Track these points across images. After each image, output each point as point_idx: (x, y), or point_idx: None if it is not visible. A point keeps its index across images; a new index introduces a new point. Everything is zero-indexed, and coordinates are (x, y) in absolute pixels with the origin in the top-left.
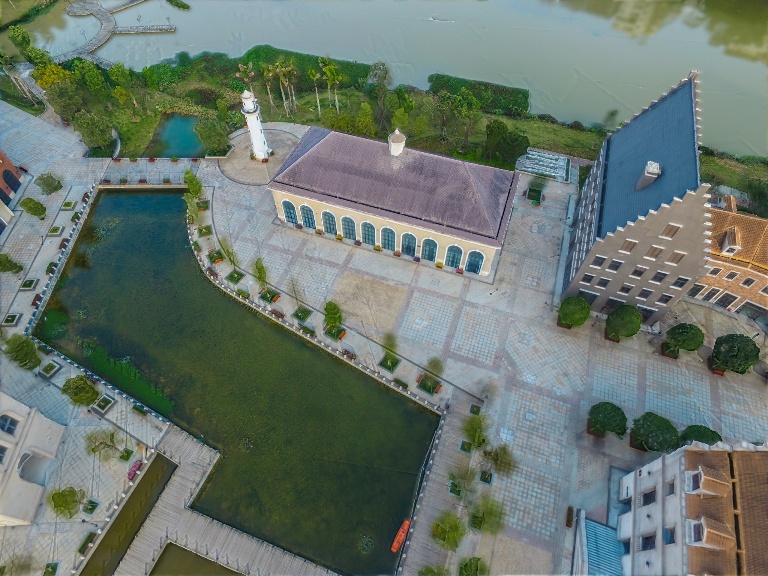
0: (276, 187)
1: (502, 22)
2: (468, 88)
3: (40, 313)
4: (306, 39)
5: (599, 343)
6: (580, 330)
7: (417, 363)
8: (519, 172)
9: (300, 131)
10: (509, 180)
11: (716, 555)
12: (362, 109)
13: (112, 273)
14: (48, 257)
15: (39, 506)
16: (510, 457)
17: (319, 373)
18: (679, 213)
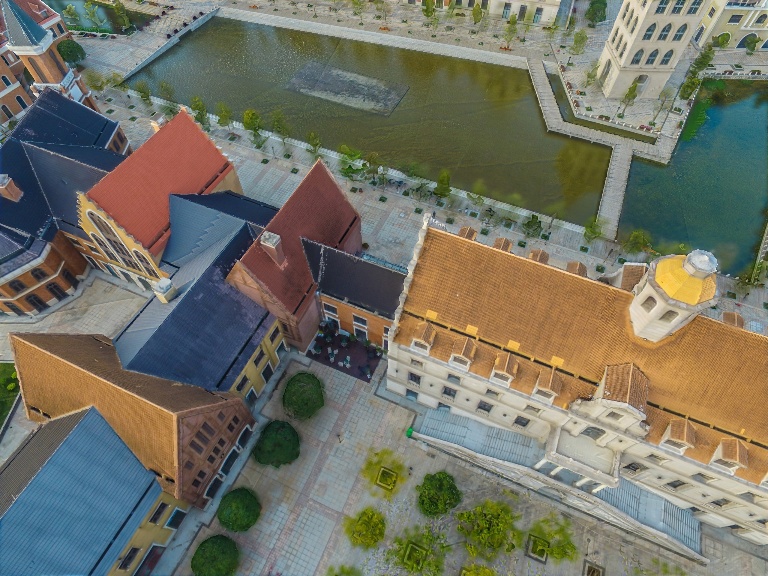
0: None
1: None
2: None
3: (719, 77)
4: None
5: None
6: None
7: None
8: None
9: None
10: None
11: None
12: None
13: (767, 101)
14: (763, 70)
15: (615, 99)
16: None
17: (748, 211)
18: None
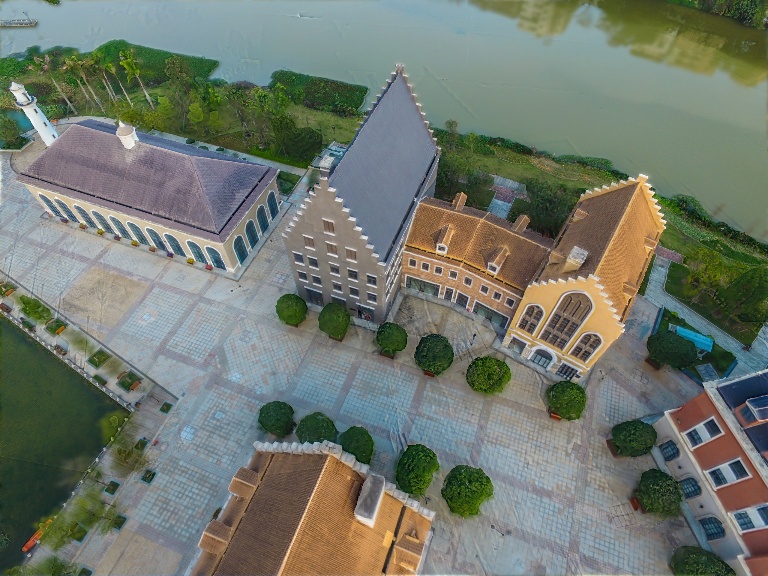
0: (22, 180)
1: (369, 19)
2: (307, 84)
3: None
4: (164, 34)
5: (321, 342)
6: (307, 328)
7: (127, 359)
8: (312, 169)
9: None
10: (258, 175)
11: (211, 559)
12: (161, 103)
13: None
14: None
15: None
16: (181, 456)
17: (27, 368)
18: (322, 208)
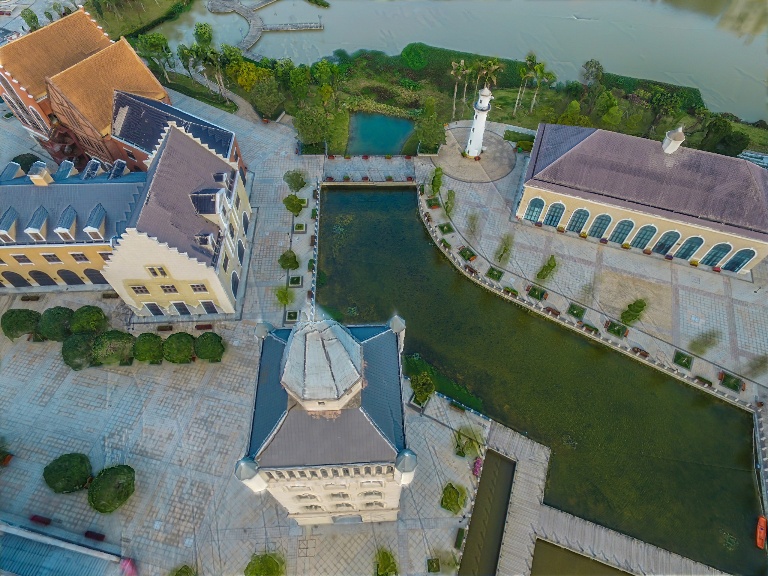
0: (535, 185)
1: (646, 21)
2: (638, 87)
3: (314, 310)
4: (457, 37)
5: None
6: None
7: (711, 361)
8: None
9: (499, 129)
10: (767, 178)
11: None
12: (571, 107)
13: (366, 270)
14: (302, 254)
15: None
16: None
17: (613, 370)
18: None
